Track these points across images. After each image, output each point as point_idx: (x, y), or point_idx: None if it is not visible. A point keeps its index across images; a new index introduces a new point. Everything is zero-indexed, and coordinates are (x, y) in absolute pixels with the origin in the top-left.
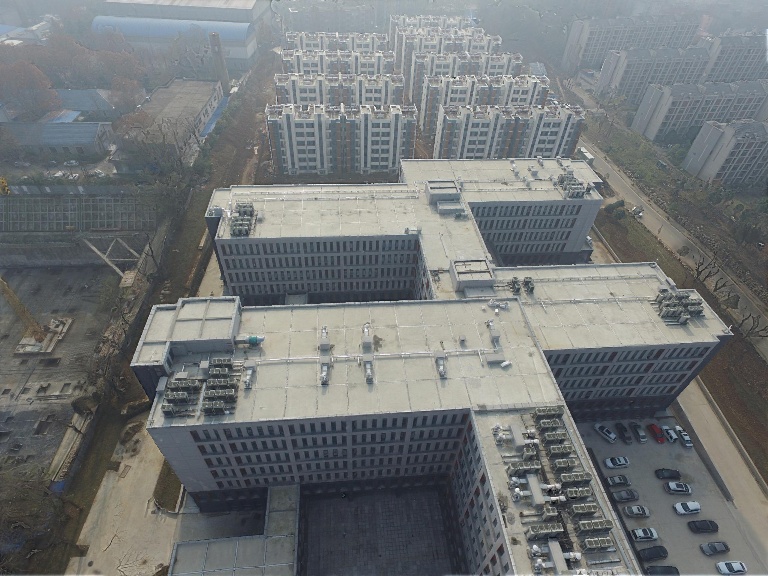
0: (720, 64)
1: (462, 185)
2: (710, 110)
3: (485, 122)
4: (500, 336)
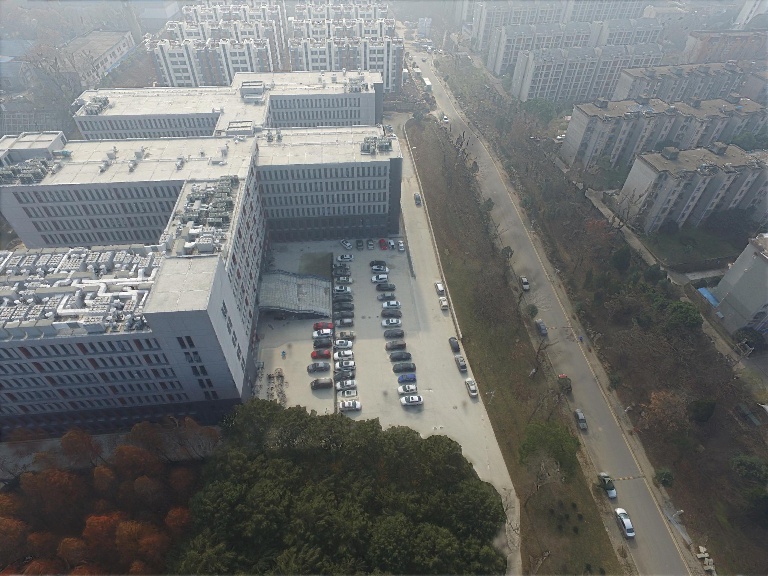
0: (578, 13)
1: (273, 86)
2: (544, 47)
3: (321, 50)
4: (230, 152)
